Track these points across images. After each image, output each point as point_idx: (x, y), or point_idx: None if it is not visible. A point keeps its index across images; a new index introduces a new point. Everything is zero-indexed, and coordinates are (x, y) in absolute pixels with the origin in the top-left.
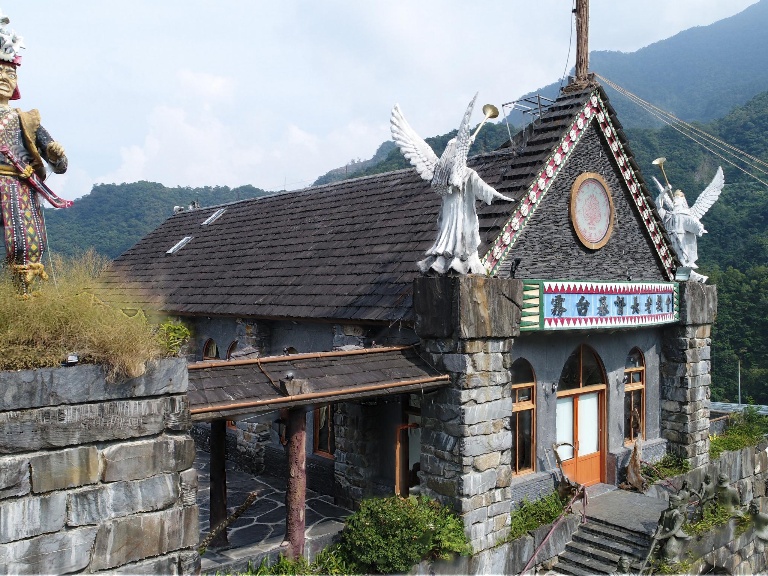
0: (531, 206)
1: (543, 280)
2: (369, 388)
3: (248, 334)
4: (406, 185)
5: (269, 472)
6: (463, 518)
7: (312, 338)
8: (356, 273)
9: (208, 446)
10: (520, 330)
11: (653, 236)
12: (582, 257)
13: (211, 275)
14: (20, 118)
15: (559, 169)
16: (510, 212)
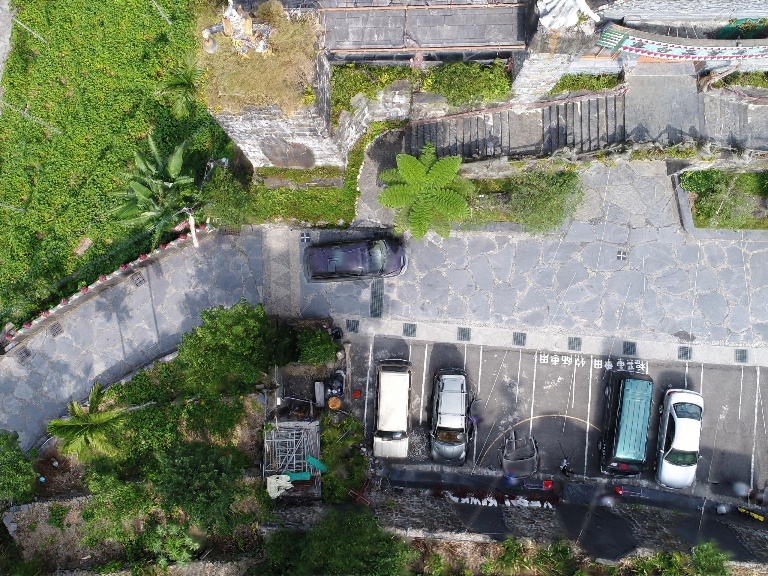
0: None
1: (630, 35)
2: (458, 49)
3: None
4: None
5: None
6: (512, 86)
7: None
8: None
9: None
10: None
11: None
12: None
13: None
14: (245, 33)
15: None
16: None
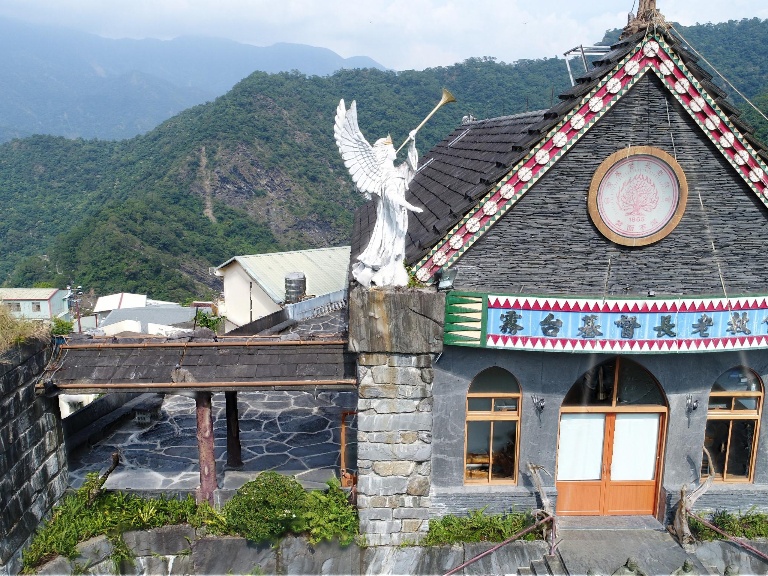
0: (506, 202)
1: (488, 293)
2: (254, 384)
3: None
4: (522, 135)
5: None
6: (358, 512)
7: None
8: None
9: None
10: (454, 344)
11: None
12: (614, 255)
13: None
14: None
15: (562, 152)
16: (458, 214)
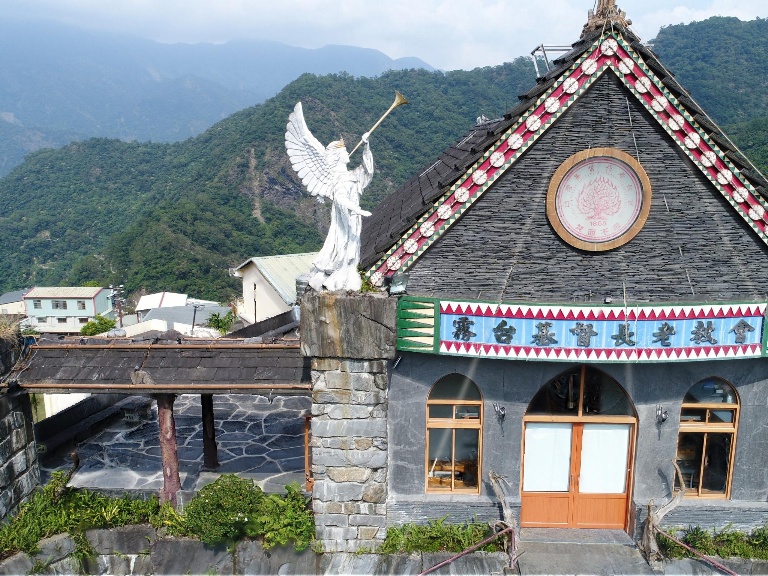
0: (461, 205)
1: (440, 299)
2: (210, 387)
3: None
4: None
5: None
6: (314, 517)
7: None
8: None
9: None
10: (408, 350)
11: (762, 226)
12: (575, 261)
13: None
14: None
15: (518, 154)
16: (411, 218)
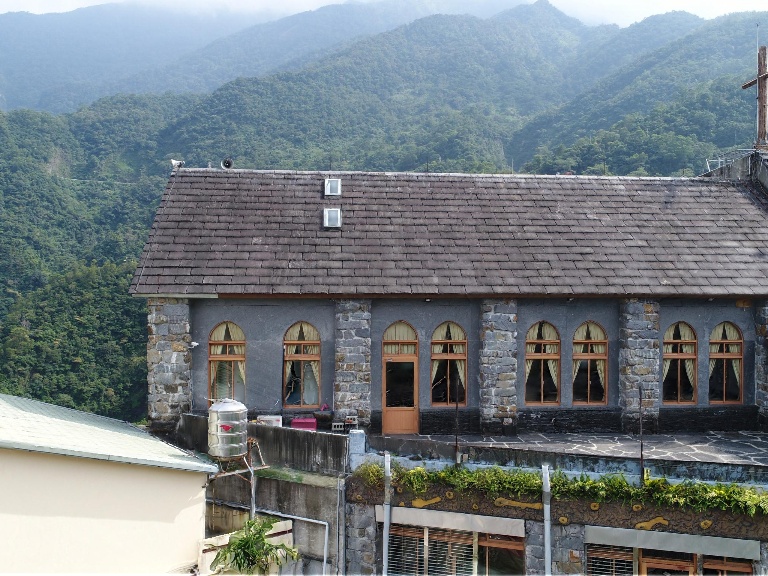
0: None
1: None
2: None
3: (648, 312)
4: (644, 192)
5: (662, 430)
6: None
7: (710, 312)
8: (743, 261)
9: (554, 427)
10: None
11: None
12: None
13: (512, 257)
14: None
15: None
16: None
